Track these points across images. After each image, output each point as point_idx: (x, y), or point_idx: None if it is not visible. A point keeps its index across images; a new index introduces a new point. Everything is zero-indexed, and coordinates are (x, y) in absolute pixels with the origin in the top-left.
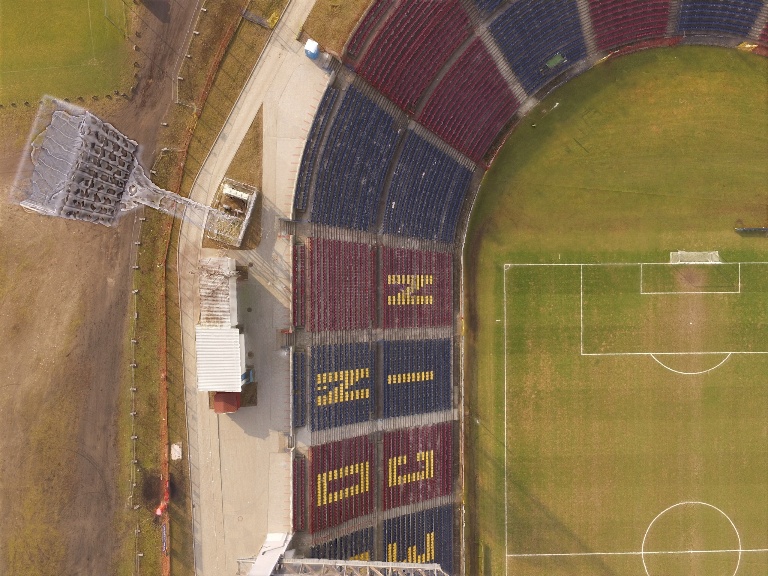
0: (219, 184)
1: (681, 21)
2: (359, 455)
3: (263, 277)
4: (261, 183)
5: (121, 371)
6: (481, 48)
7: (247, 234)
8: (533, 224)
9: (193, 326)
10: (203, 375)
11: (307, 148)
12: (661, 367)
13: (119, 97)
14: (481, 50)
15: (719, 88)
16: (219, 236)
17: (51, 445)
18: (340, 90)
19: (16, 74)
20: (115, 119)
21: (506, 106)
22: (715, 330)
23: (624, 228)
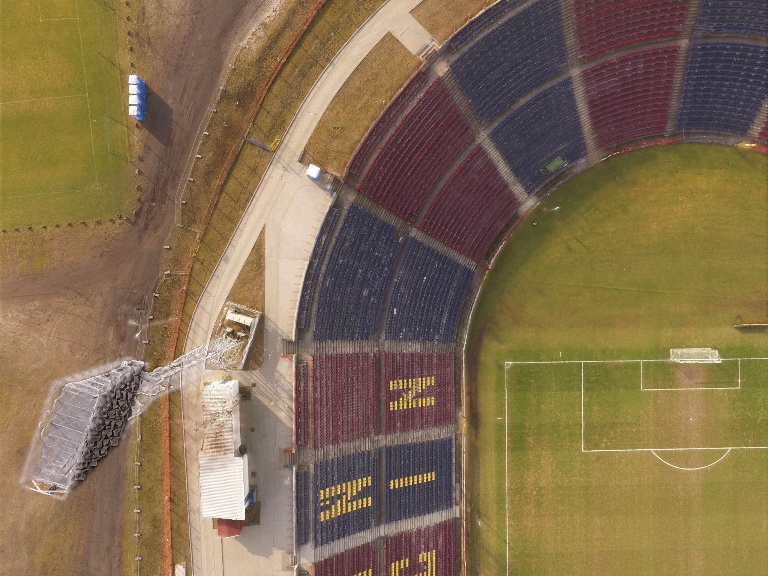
0: (222, 306)
1: (680, 120)
2: (362, 563)
3: (266, 397)
4: (264, 304)
5: (125, 493)
6: (482, 154)
7: (250, 355)
8: (534, 322)
9: (196, 447)
10: (207, 501)
11: (309, 268)
12: (661, 463)
13: (122, 221)
14: (482, 156)
15: (718, 185)
16: (222, 359)
17: (55, 567)
18: (342, 209)
19: (19, 199)
20: (118, 243)
21: (507, 206)
22: (715, 426)
23: (624, 325)
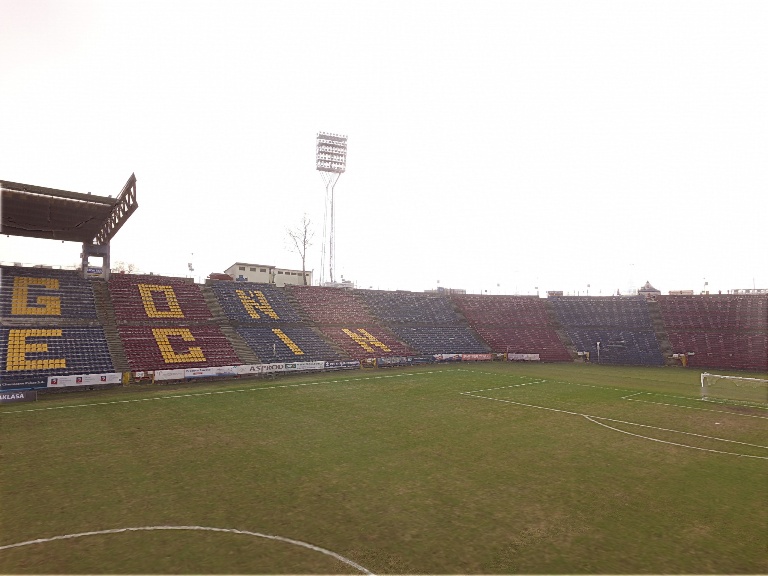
0: None
1: None
2: None
3: None
4: None
5: None
6: None
7: None
8: None
9: None
10: None
11: None
12: (594, 424)
13: None
14: None
15: None
16: None
17: None
18: None
19: None
20: None
21: None
22: None
23: None
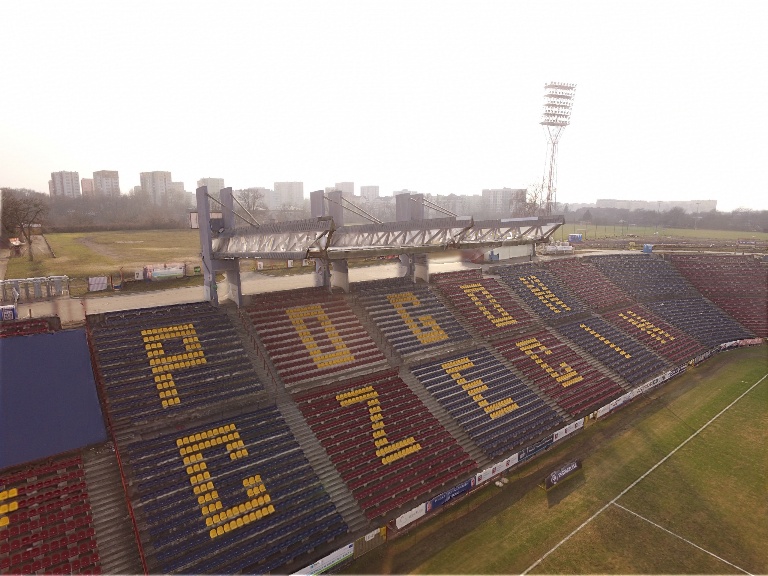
0: None
1: None
2: None
3: None
4: None
5: None
6: None
7: None
8: None
9: None
10: None
11: (617, 257)
12: None
13: None
14: None
15: None
16: None
17: None
18: None
19: None
20: None
21: None
22: None
23: None
